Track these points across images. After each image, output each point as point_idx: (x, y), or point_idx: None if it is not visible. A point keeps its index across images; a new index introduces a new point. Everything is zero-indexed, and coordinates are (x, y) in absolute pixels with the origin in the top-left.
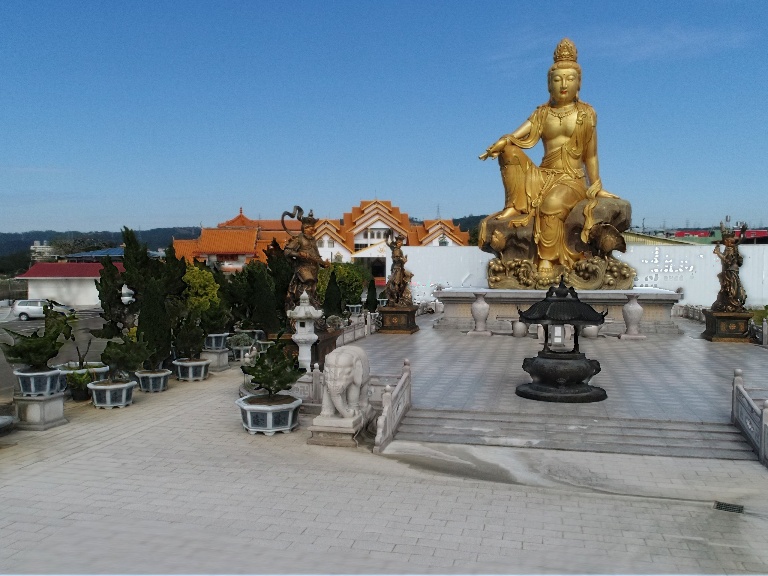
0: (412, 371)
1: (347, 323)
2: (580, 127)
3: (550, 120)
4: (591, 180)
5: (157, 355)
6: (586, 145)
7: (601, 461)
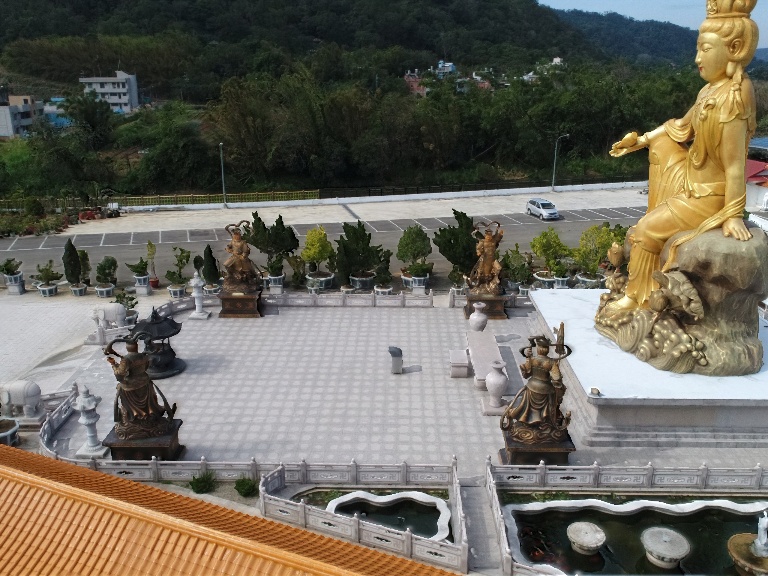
0: (248, 333)
1: (525, 291)
2: (702, 124)
3: (694, 107)
4: (724, 202)
5: (207, 280)
6: (717, 150)
7: (54, 381)
